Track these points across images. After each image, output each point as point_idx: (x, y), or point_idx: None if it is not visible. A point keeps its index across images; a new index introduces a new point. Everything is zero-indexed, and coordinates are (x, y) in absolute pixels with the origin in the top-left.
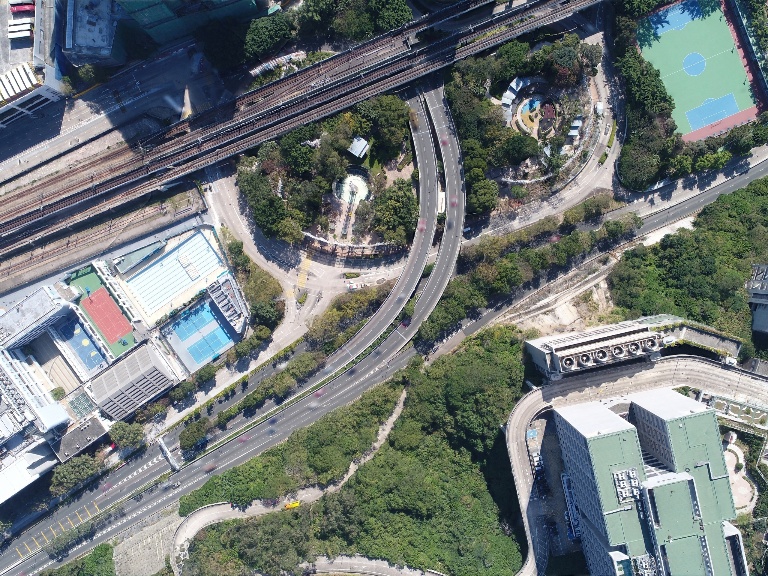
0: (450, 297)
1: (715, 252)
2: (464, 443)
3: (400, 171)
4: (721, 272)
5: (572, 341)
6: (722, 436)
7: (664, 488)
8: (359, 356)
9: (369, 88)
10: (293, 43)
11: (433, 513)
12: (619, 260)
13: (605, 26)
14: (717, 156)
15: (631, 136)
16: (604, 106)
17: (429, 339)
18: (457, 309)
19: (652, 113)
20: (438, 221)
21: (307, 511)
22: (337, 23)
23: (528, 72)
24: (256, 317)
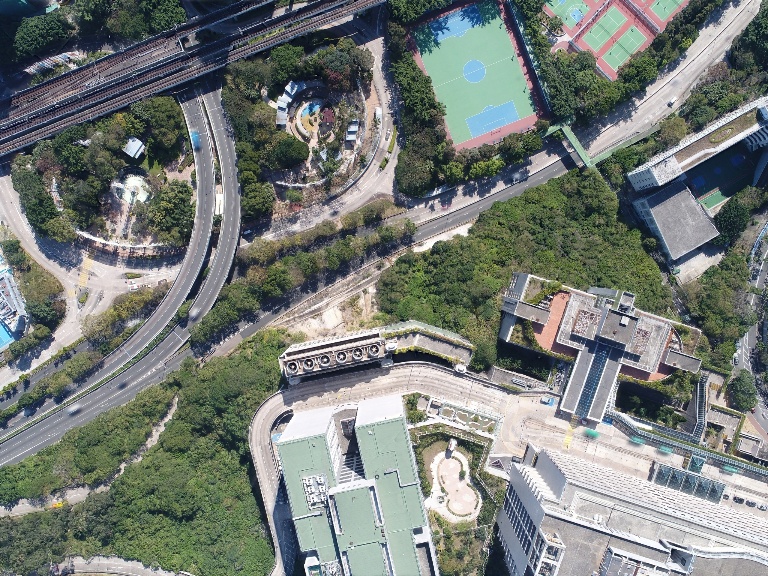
0: (225, 299)
1: (477, 259)
2: (235, 445)
3: (181, 172)
4: (478, 279)
5: (307, 346)
6: (446, 443)
7: (345, 494)
8: (136, 357)
9: (143, 89)
10: (74, 42)
11: (194, 515)
12: (392, 265)
13: (385, 31)
14: (487, 163)
15: (406, 142)
16: (385, 111)
17: (206, 341)
18: (227, 311)
19: (422, 119)
20: (214, 223)
21: (66, 511)
22: (110, 23)
23: (299, 76)
24: (32, 316)
